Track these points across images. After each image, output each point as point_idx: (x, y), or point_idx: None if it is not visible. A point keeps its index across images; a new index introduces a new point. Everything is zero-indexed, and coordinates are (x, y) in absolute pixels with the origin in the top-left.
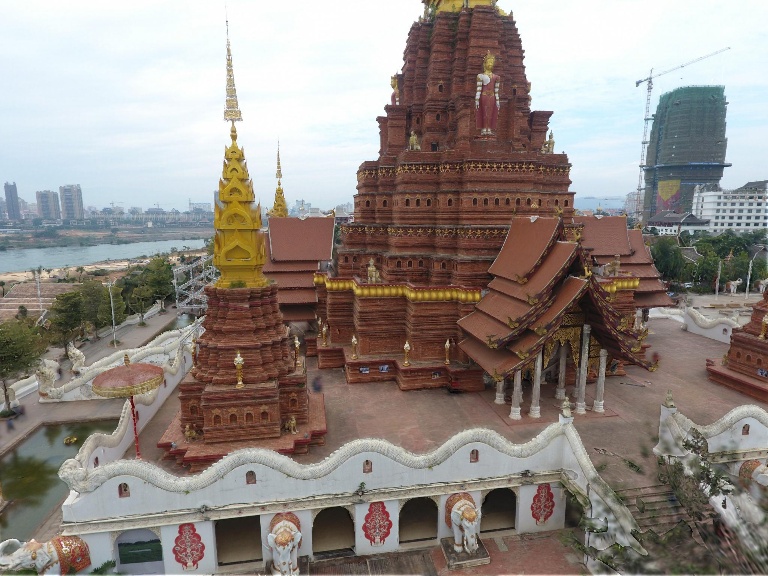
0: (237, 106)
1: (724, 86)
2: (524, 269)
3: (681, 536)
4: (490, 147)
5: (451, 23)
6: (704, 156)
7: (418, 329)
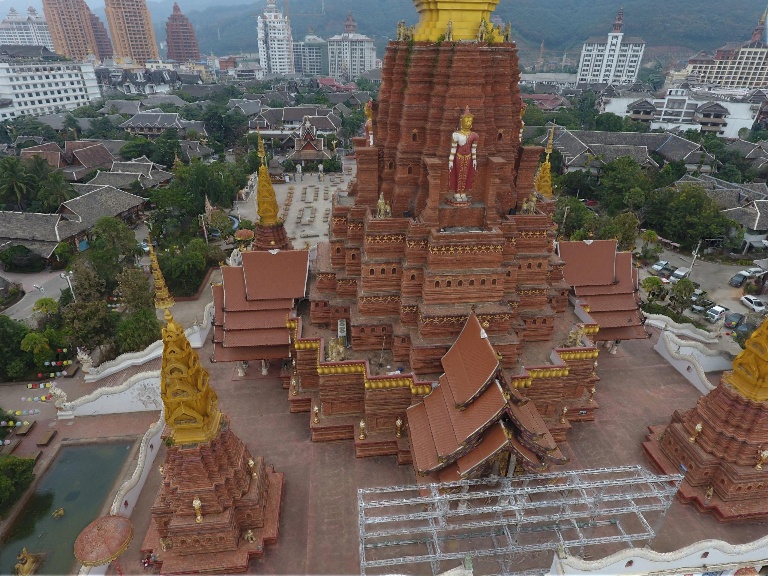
0: None
1: None
2: (608, 275)
3: (743, 332)
4: None
5: None
6: None
7: None
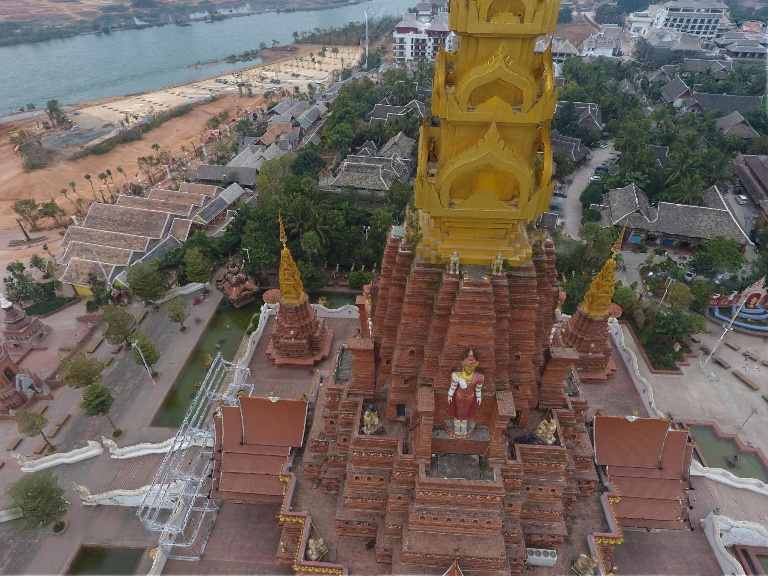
0: None
1: None
2: None
3: None
4: (460, 444)
5: (432, 280)
6: None
7: None
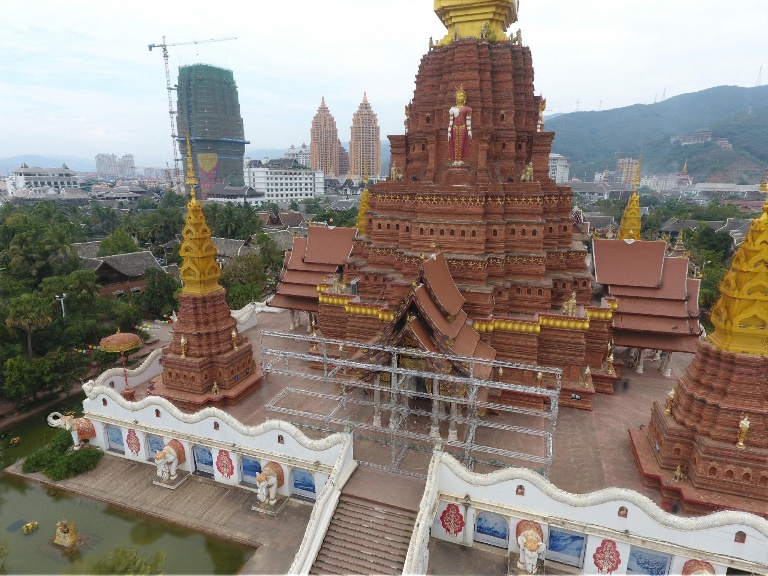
0: None
1: (232, 71)
2: (652, 278)
3: None
4: None
5: None
6: (231, 133)
7: None
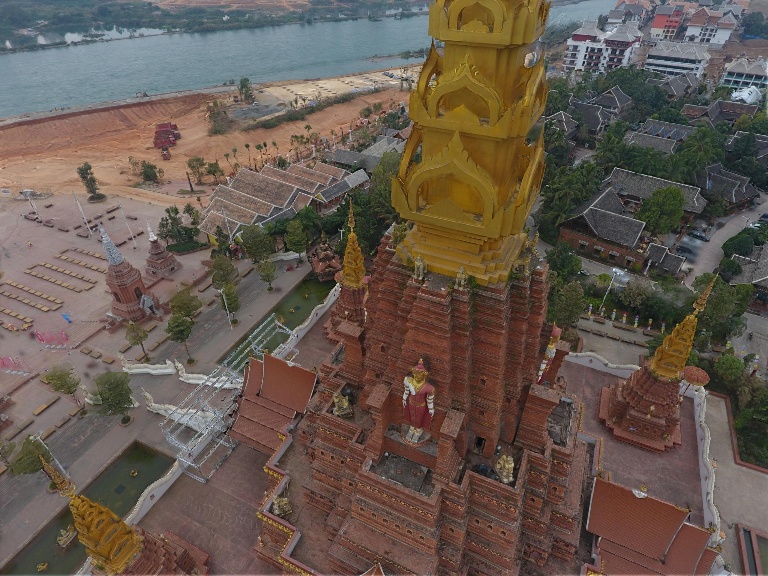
0: (64, 487)
1: None
2: None
3: None
4: (411, 450)
5: (402, 281)
6: None
7: (289, 575)
